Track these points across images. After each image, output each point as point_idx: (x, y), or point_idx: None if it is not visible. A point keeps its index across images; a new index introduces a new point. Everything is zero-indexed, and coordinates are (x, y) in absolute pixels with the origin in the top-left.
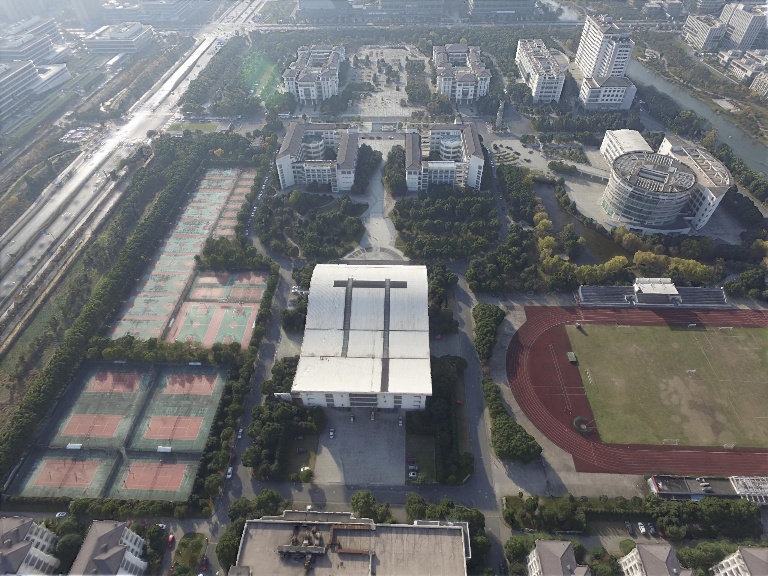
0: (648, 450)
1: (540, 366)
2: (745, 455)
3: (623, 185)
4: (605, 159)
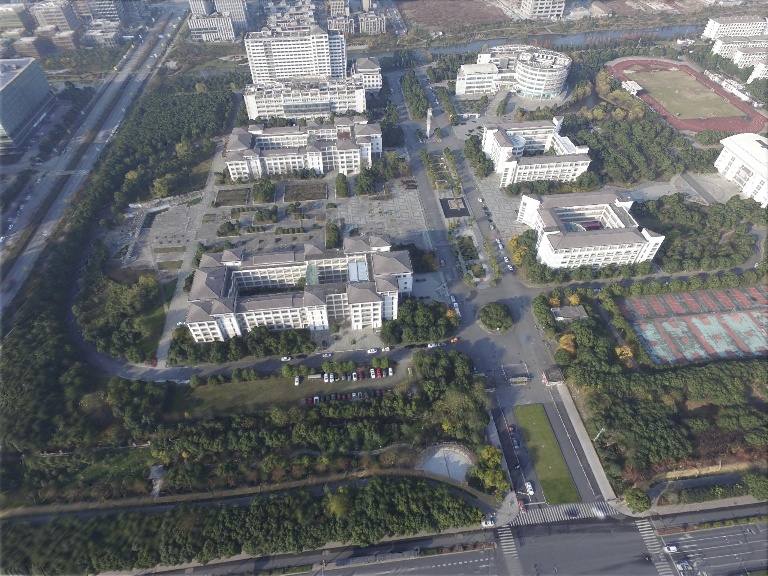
0: (738, 106)
1: (721, 127)
2: (713, 88)
3: (561, 72)
4: (471, 94)
